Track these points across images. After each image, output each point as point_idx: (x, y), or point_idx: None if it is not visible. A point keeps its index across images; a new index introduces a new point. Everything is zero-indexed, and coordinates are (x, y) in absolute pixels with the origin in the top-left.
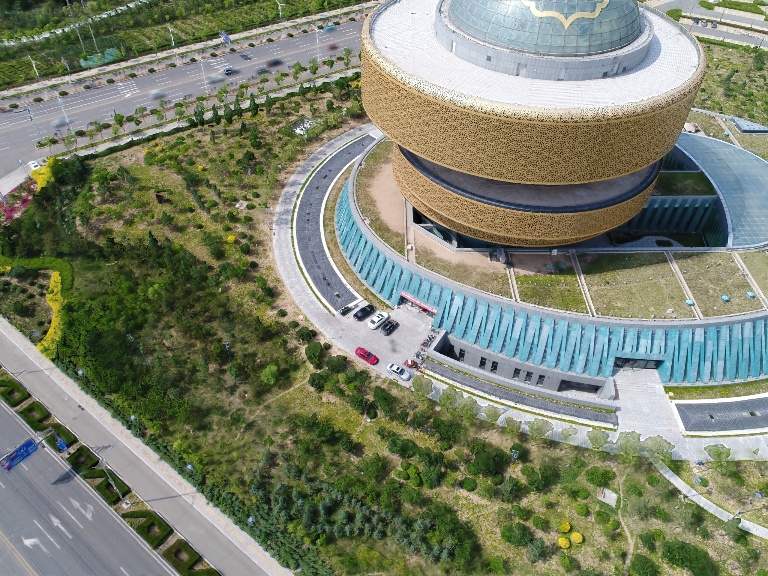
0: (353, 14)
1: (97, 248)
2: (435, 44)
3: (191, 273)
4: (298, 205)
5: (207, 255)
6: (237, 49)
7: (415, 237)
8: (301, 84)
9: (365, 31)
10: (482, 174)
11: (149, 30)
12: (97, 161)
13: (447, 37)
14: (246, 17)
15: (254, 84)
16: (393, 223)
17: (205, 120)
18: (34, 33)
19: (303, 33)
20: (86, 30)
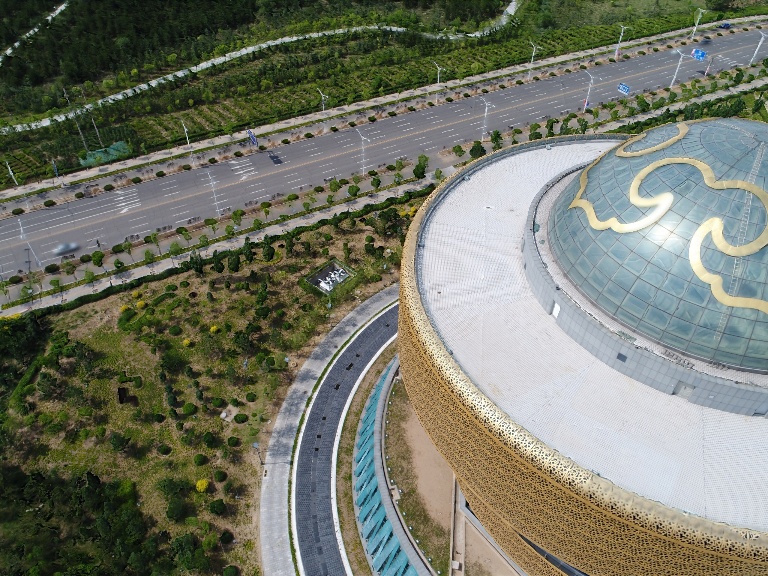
0: (413, 101)
1: (21, 479)
2: (522, 289)
3: (129, 560)
4: (306, 418)
5: (164, 510)
6: (268, 147)
7: (466, 540)
8: (335, 215)
9: (408, 256)
10: (596, 575)
11: (168, 118)
12: (61, 317)
13: (545, 291)
14: (285, 102)
15: (279, 202)
16: (434, 504)
17: (208, 258)
18: (32, 121)
19: (350, 126)
20: (94, 117)
